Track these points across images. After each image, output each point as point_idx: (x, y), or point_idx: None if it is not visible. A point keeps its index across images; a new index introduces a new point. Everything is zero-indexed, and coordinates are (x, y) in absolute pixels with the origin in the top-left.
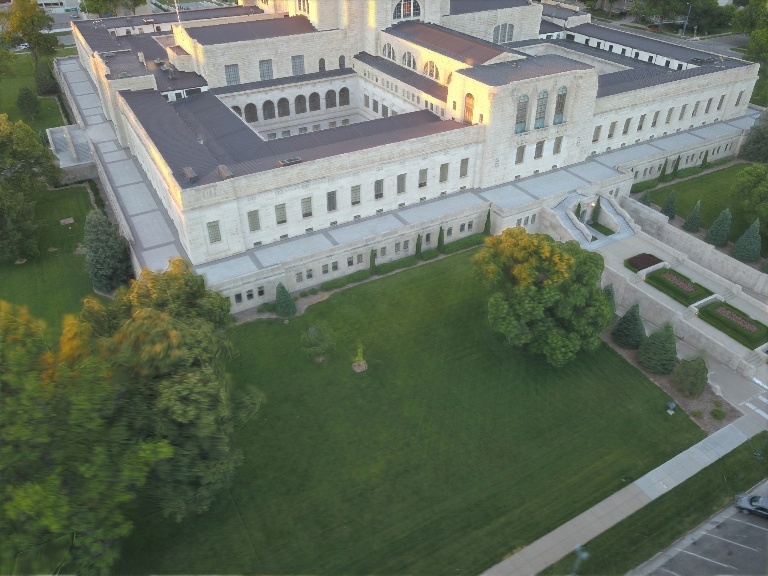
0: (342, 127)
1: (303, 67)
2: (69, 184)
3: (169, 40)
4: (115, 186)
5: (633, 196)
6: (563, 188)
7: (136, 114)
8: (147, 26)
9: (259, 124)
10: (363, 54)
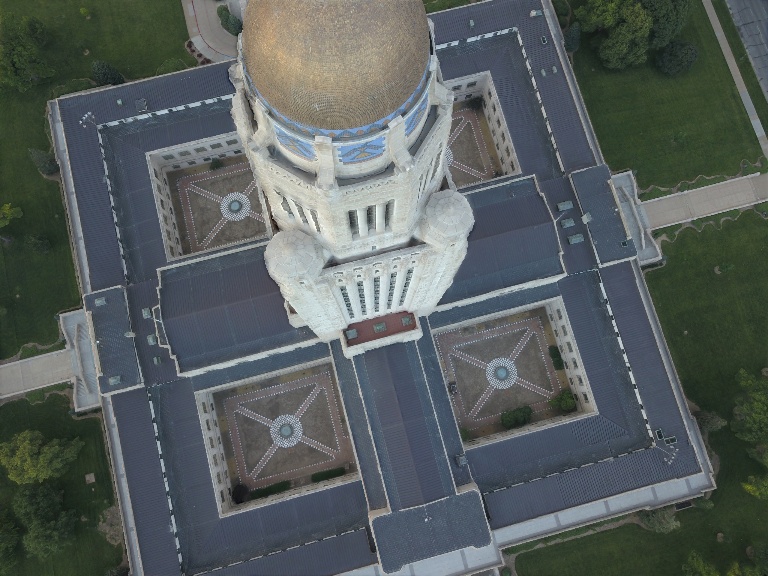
0: (283, 503)
1: (279, 352)
2: (87, 412)
3: (165, 152)
4: (119, 475)
5: (507, 557)
6: (441, 570)
7: (126, 458)
8: (140, 115)
9: (237, 384)
10: None
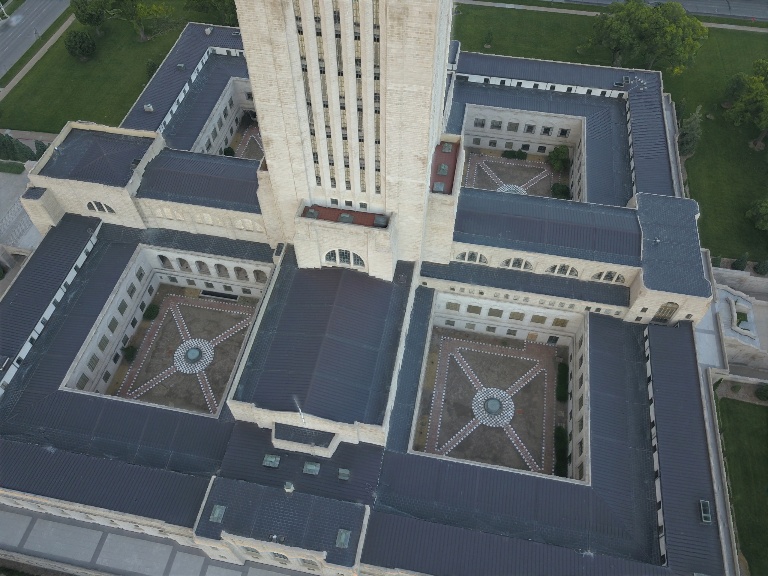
0: (592, 402)
1: None
2: None
3: (75, 371)
4: None
5: None
6: None
7: None
8: (7, 373)
9: None
10: (423, 264)
